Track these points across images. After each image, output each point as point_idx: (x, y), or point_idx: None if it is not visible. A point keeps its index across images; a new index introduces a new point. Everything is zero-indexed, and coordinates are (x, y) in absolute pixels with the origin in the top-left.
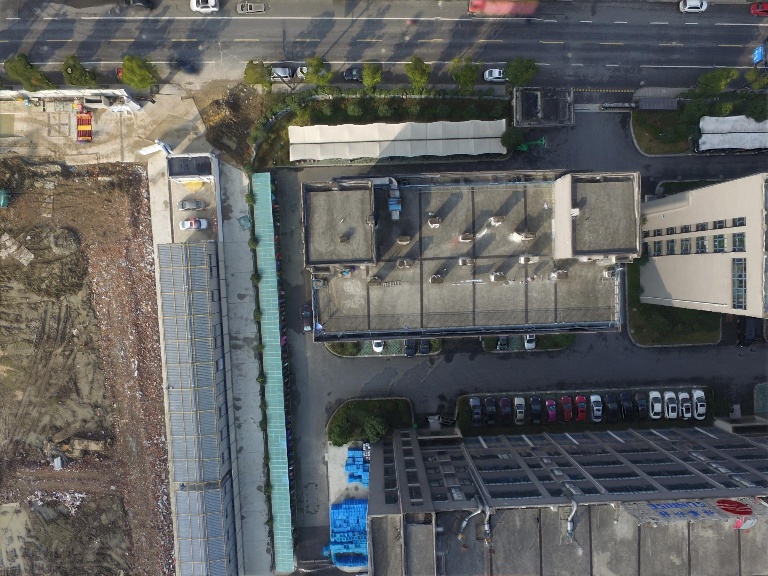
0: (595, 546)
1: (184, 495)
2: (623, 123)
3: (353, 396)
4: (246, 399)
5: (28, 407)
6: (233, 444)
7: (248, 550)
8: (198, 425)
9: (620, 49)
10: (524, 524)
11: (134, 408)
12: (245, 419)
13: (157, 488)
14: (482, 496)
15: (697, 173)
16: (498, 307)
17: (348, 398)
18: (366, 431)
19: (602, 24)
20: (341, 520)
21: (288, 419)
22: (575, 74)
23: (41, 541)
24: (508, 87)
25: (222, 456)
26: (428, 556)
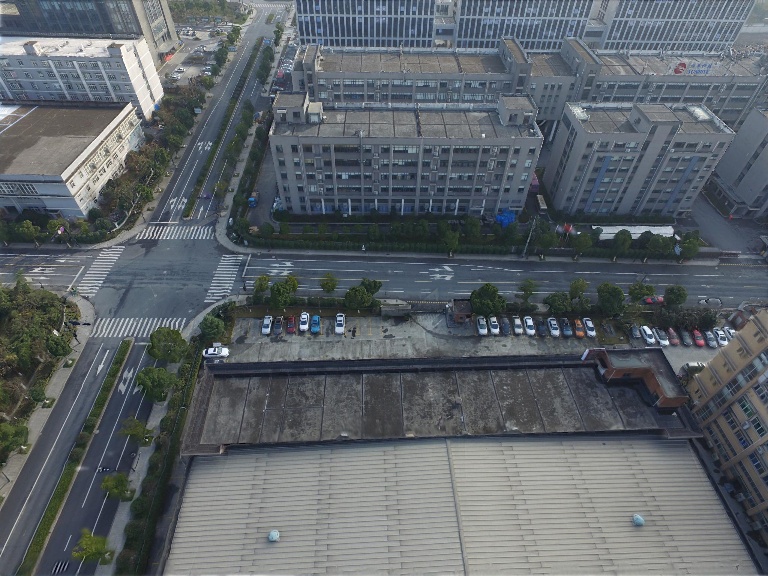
0: None
1: None
2: None
3: None
4: None
5: None
6: None
7: None
8: None
9: None
10: None
11: None
12: None
13: None
14: (765, 83)
15: None
16: None
17: None
18: None
19: (767, 297)
20: None
21: None
22: None
23: None
24: None
25: None
26: None
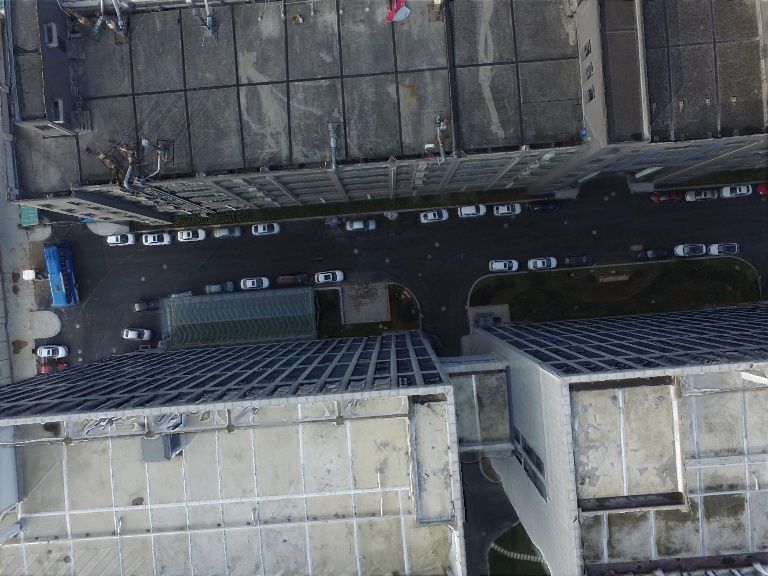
0: (240, 46)
1: None
2: None
3: None
4: None
5: None
6: None
7: (1, 215)
8: None
9: None
10: (164, 26)
11: None
12: None
13: None
14: None
15: None
16: None
17: None
18: None
19: None
20: None
21: None
22: None
23: None
24: None
25: None
26: (34, 22)
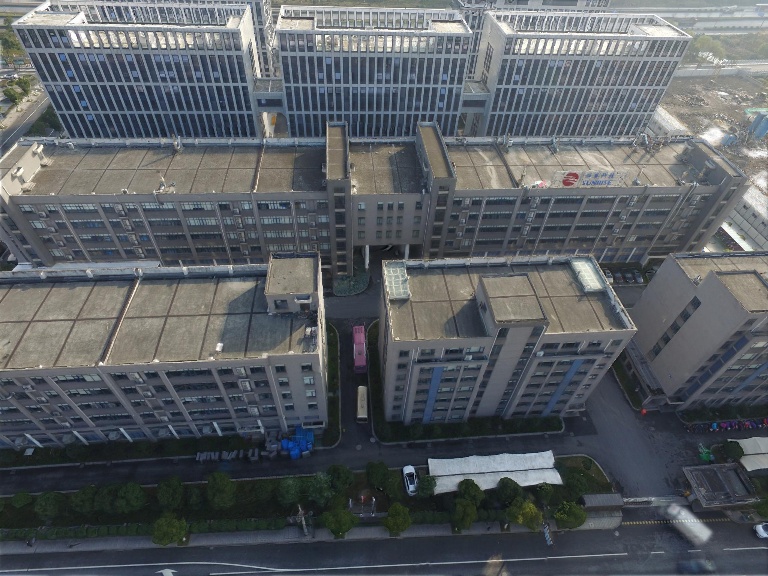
0: None
1: None
2: (620, 487)
3: None
4: None
5: None
6: None
7: None
8: None
9: (658, 574)
10: (661, 184)
11: None
12: None
13: None
14: None
15: (532, 441)
16: (753, 265)
17: None
18: None
19: None
20: None
21: None
22: (692, 540)
23: None
24: (752, 520)
25: None
26: None
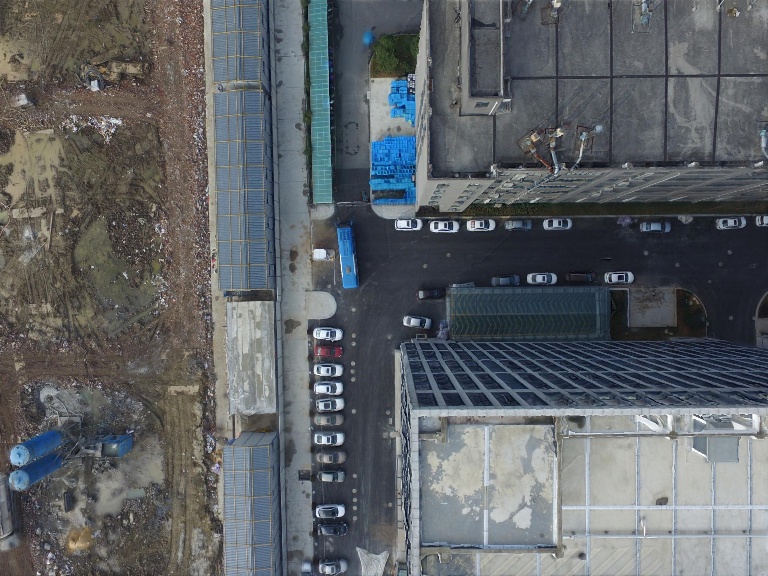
0: (671, 35)
1: (223, 95)
2: None
3: (398, 31)
4: (287, 31)
5: (67, 31)
6: (273, 71)
7: (284, 191)
8: (240, 20)
9: None
10: (593, 9)
11: (173, 35)
12: (286, 52)
13: (193, 120)
14: None
15: None
16: None
17: (393, 33)
18: (412, 49)
19: None
20: (382, 153)
21: (330, 49)
22: None
23: (74, 170)
24: None
25: (263, 63)
26: None
